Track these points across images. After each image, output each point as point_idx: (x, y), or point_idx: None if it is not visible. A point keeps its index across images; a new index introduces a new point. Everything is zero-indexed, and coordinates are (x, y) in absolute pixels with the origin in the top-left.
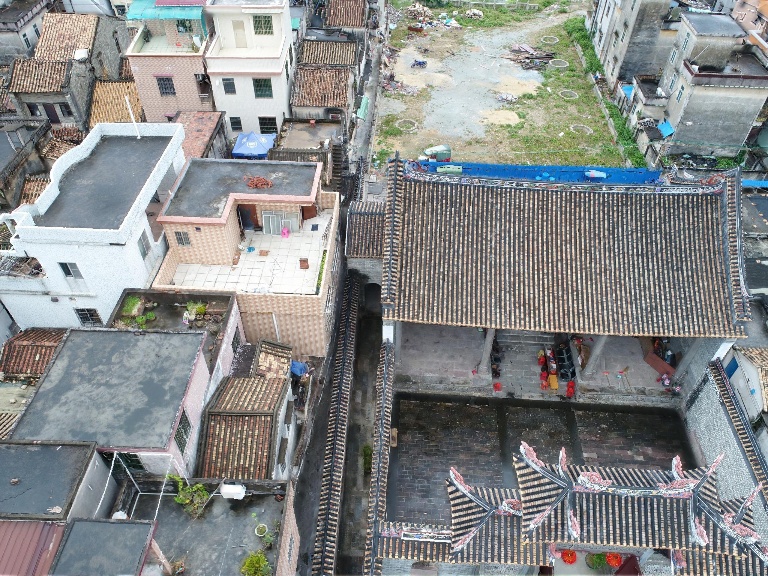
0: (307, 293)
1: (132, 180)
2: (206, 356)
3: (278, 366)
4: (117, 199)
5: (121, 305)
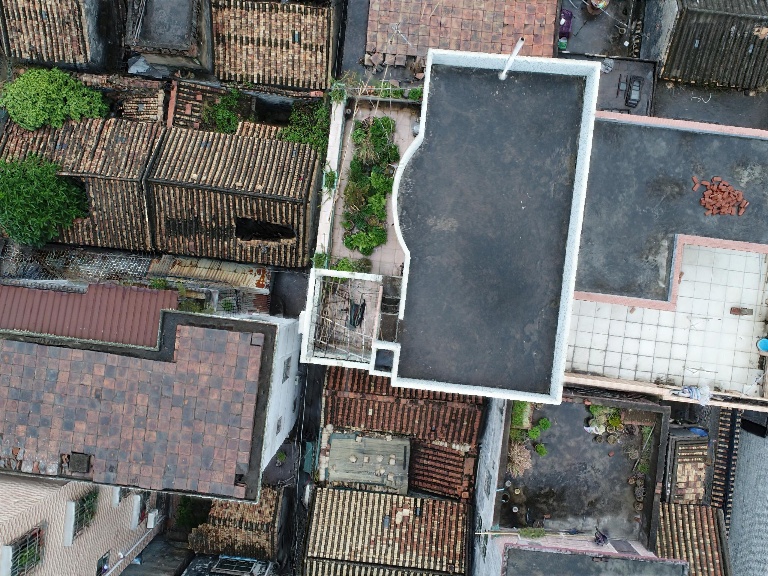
0: (762, 399)
1: (524, 224)
2: (625, 492)
3: (696, 476)
4: (512, 280)
5: (510, 419)
